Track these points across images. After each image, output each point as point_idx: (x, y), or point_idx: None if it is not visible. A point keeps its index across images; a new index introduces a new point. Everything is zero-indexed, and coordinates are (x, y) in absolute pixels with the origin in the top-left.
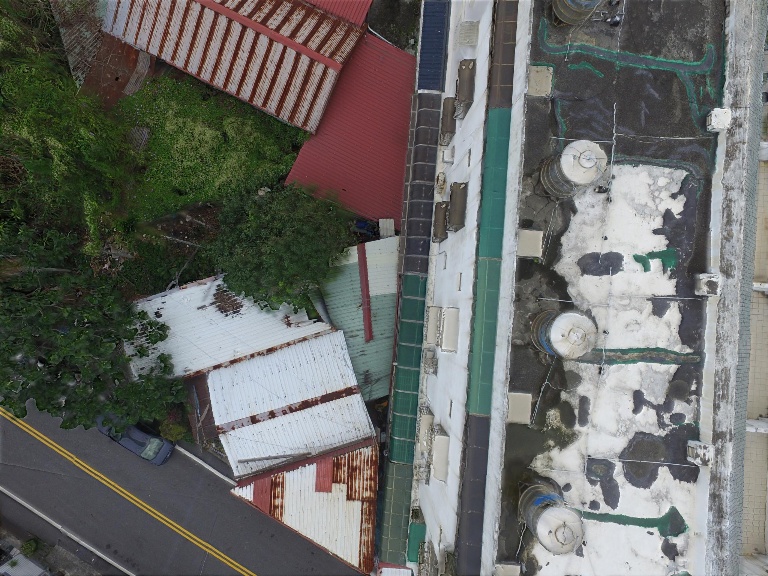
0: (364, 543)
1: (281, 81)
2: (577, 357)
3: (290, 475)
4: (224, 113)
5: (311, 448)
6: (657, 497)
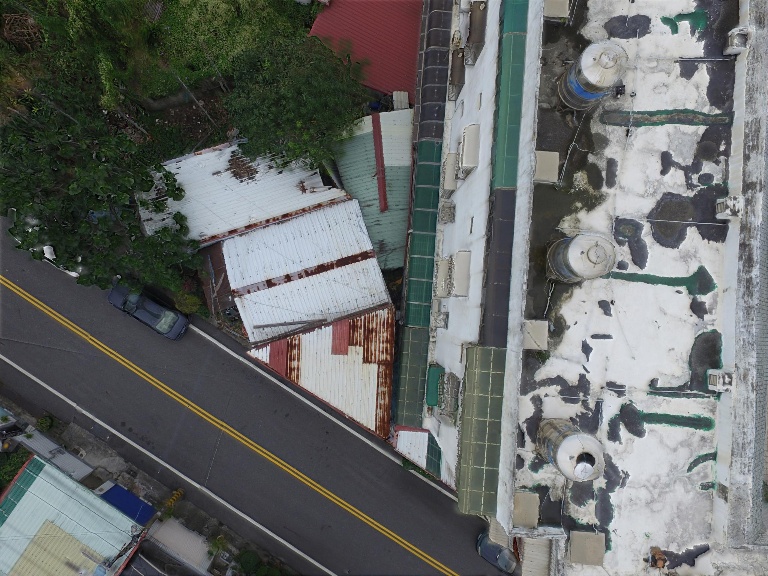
0: (380, 407)
1: None
2: (608, 86)
3: (306, 337)
4: None
5: (327, 314)
6: (686, 256)
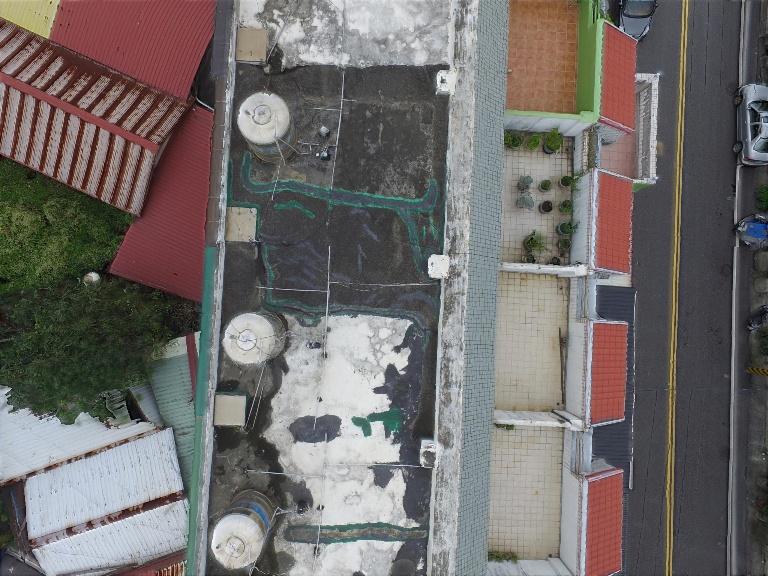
0: None
1: (98, 162)
2: (243, 566)
3: None
4: (51, 192)
5: (137, 558)
6: None
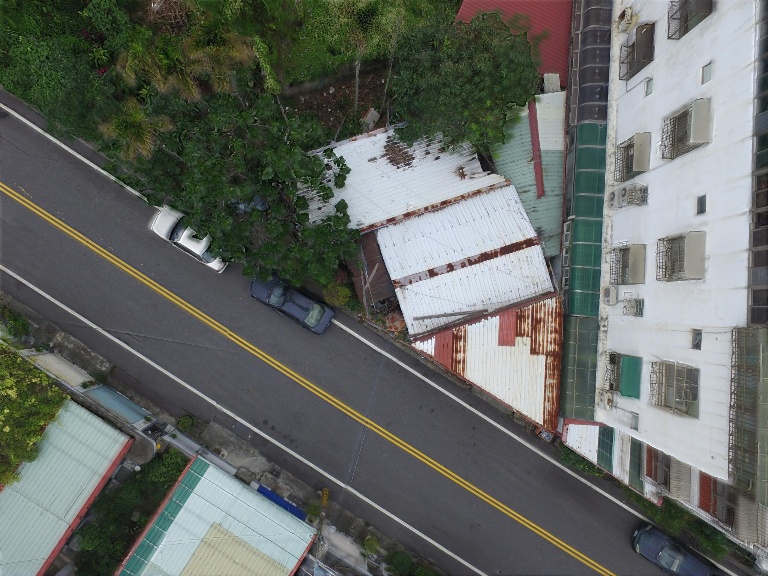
0: (548, 400)
1: None
2: None
3: (472, 329)
4: None
5: (488, 305)
6: None
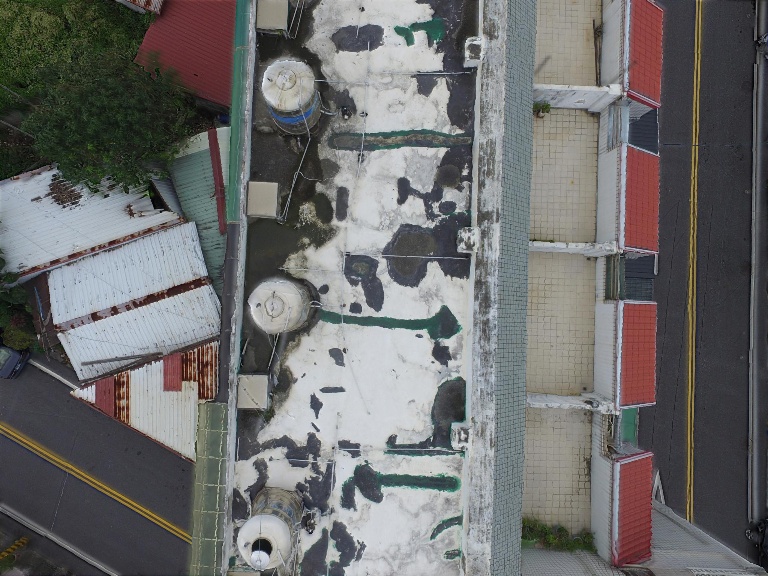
0: None
1: None
2: (294, 109)
3: (135, 374)
4: (69, 1)
5: (162, 347)
6: (426, 296)
